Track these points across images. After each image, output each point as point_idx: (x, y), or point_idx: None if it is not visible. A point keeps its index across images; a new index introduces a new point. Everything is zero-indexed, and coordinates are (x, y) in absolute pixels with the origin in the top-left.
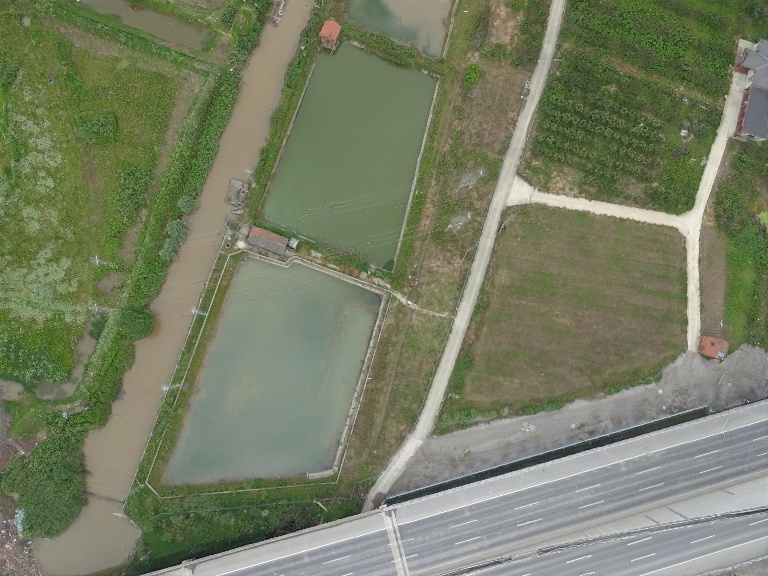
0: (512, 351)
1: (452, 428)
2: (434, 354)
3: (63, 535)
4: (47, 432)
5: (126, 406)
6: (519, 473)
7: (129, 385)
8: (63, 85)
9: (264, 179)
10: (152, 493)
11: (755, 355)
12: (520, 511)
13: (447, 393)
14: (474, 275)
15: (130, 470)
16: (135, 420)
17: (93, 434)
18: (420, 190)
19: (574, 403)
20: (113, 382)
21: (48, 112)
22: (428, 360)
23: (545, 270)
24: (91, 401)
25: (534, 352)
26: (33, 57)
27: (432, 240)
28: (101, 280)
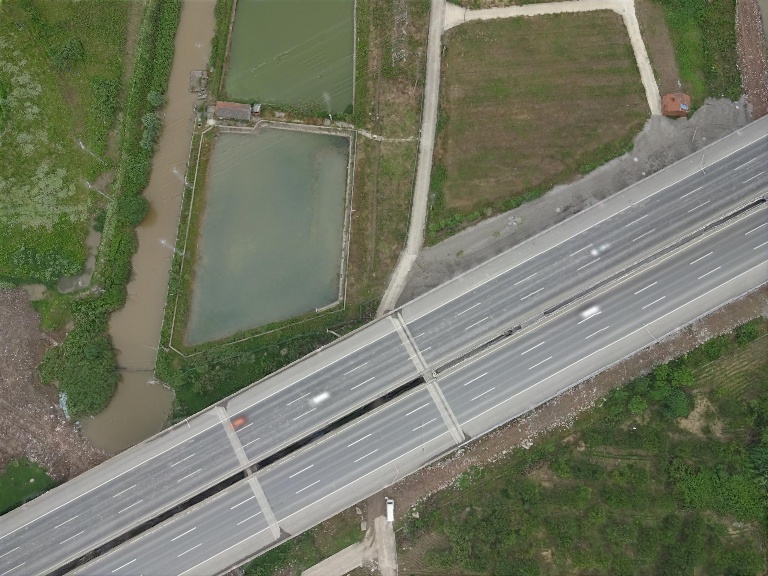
0: (481, 154)
1: (441, 237)
2: (408, 175)
3: (106, 411)
4: (74, 321)
5: (139, 286)
6: (510, 250)
7: (138, 267)
8: (31, 28)
9: (219, 61)
10: (177, 355)
11: (722, 106)
12: (520, 286)
13: (429, 206)
14: (429, 97)
15: (154, 341)
16: (150, 296)
17: (115, 316)
18: (361, 37)
19: (554, 189)
20: (123, 265)
21: (23, 53)
22: (404, 182)
23: (494, 76)
24: (106, 284)
25: (502, 151)
26: (2, 12)
27: (382, 77)
28: (95, 181)
